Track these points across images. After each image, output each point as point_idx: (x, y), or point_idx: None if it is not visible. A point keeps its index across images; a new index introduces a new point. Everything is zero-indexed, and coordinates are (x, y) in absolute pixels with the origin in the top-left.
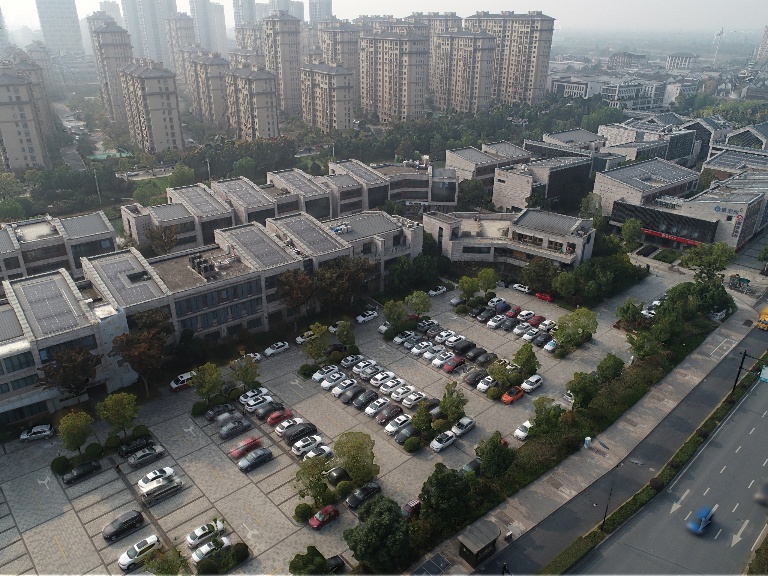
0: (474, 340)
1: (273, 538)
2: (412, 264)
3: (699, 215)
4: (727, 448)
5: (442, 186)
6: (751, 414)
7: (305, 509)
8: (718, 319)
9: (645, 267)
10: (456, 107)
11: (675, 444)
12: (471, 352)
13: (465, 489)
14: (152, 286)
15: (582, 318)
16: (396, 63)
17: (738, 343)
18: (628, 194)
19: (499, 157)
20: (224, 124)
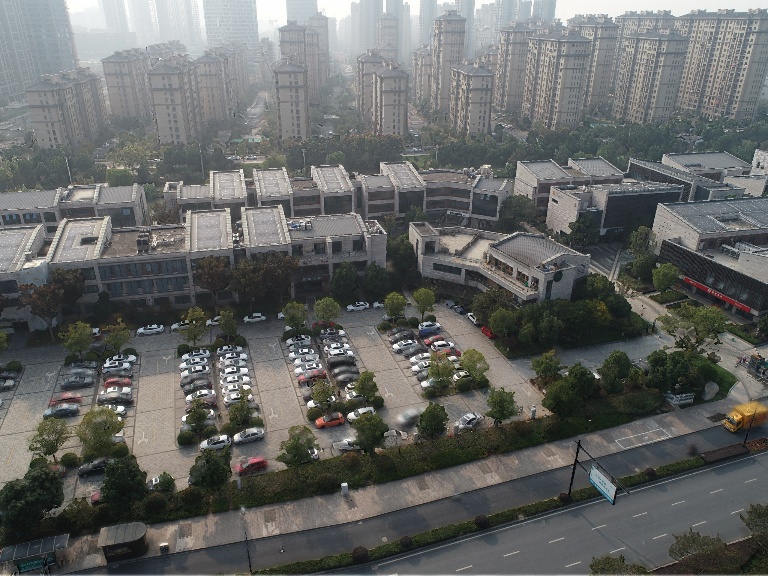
0: (363, 359)
1: (2, 478)
2: (353, 271)
3: (756, 272)
4: (499, 548)
5: (483, 199)
6: (580, 521)
7: (37, 462)
8: (676, 403)
9: (658, 324)
10: (632, 117)
11: (443, 523)
12: (338, 369)
13: (136, 487)
14: (91, 250)
15: (464, 360)
16: (553, 66)
17: (671, 437)
18: (686, 234)
19: (578, 175)
20: (371, 119)
